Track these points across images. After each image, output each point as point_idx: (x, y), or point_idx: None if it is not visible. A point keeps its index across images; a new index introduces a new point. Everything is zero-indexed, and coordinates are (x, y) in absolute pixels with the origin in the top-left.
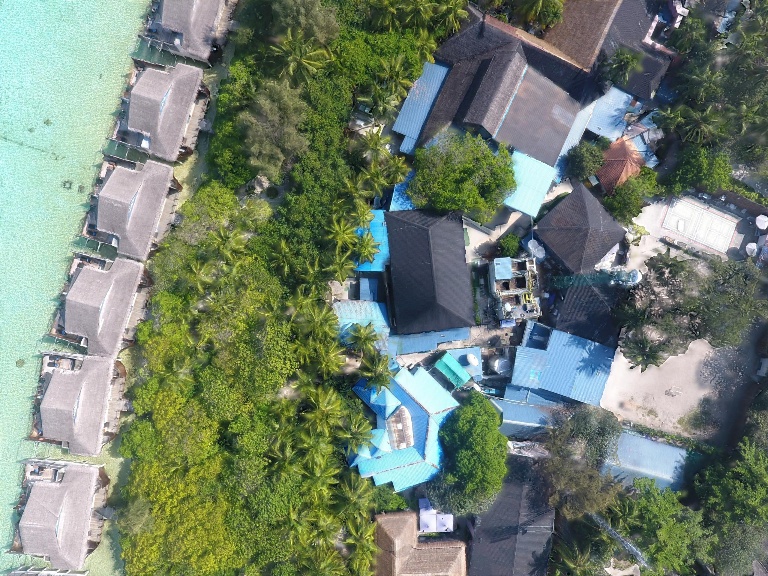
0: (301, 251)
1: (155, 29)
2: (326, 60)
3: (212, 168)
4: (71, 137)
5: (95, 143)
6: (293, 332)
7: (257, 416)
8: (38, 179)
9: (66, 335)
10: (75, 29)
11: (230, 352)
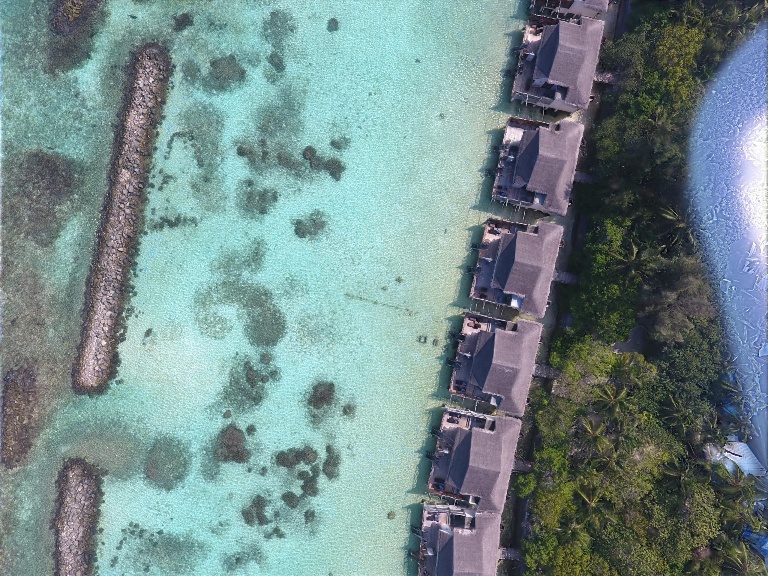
0: (701, 410)
1: (503, 185)
2: (709, 221)
3: (580, 322)
4: (422, 292)
5: (445, 297)
6: (716, 496)
7: (669, 573)
8: (394, 335)
9: (444, 490)
10: (418, 187)
11: (640, 512)
